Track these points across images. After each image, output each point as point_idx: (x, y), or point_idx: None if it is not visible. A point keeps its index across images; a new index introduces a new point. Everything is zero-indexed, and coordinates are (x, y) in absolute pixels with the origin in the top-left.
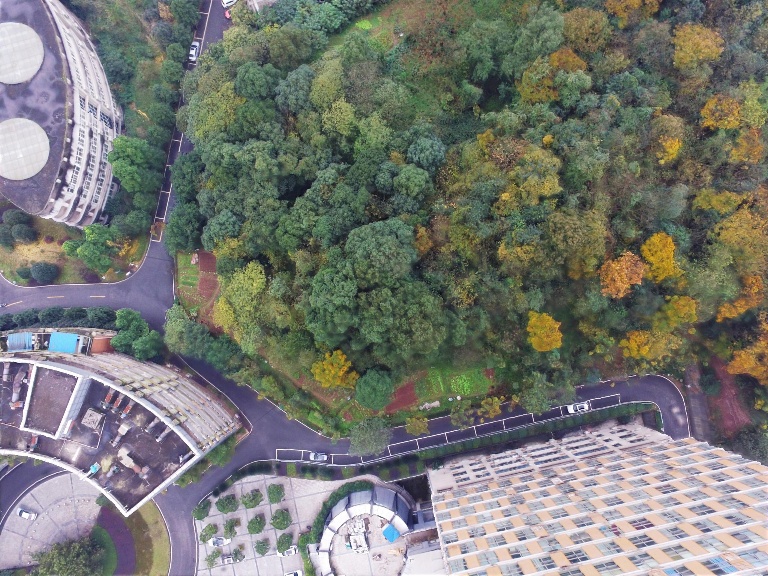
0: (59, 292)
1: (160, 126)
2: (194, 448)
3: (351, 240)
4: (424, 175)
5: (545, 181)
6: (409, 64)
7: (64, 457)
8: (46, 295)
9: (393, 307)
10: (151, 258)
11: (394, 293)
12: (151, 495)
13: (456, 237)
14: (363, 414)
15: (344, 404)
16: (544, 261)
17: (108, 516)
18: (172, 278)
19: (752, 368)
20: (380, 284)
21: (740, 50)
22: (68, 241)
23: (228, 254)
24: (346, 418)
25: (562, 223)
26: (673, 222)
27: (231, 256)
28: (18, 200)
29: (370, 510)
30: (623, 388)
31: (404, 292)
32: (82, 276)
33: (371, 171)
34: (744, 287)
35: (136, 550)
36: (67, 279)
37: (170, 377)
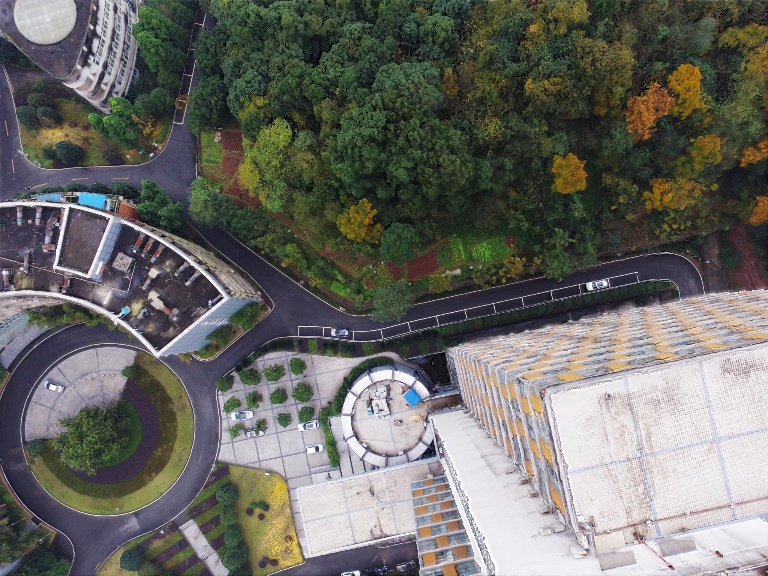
0: (83, 174)
1: (183, 5)
2: (223, 291)
3: (379, 77)
4: (450, 22)
5: (574, 6)
6: None
7: (95, 300)
8: (71, 177)
9: (421, 139)
10: (174, 140)
11: (422, 127)
12: (181, 336)
13: (482, 82)
14: (385, 281)
15: (366, 272)
16: (571, 92)
17: (133, 390)
18: (195, 160)
19: None
20: (408, 116)
21: None
22: (94, 113)
23: (254, 112)
24: (368, 286)
25: (590, 47)
26: None
27: (257, 115)
28: (46, 64)
29: (392, 375)
30: (642, 266)
31: (431, 127)
32: (106, 158)
33: (397, 21)
34: None
35: (161, 423)
36: (91, 162)
37: (195, 246)
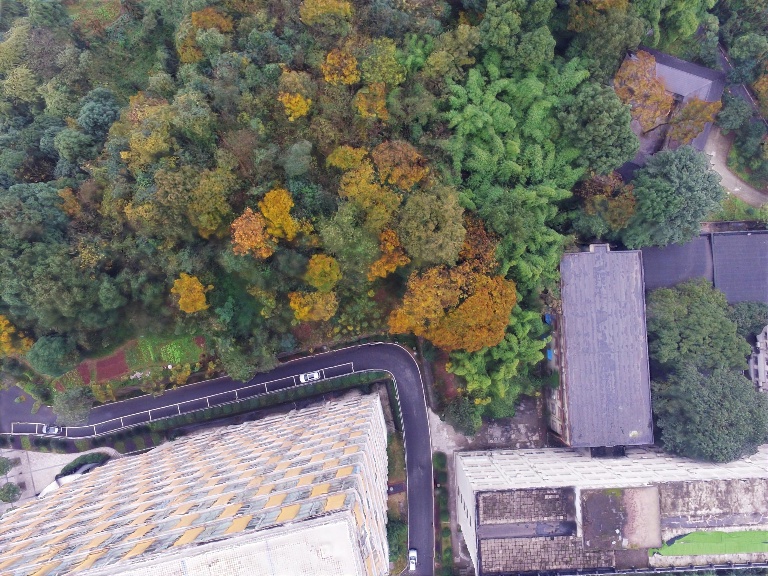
0: None
1: None
2: None
3: None
4: (78, 138)
5: (149, 137)
6: (131, 33)
7: None
8: None
9: (16, 268)
10: None
11: (20, 254)
12: None
13: (106, 199)
14: (73, 384)
15: None
16: (163, 219)
17: None
18: None
19: (413, 328)
20: None
21: (383, 7)
22: None
23: None
24: (57, 388)
25: (162, 179)
26: (308, 180)
27: None
28: None
29: None
30: (356, 357)
31: (32, 253)
32: None
33: (32, 135)
34: (380, 244)
35: None
36: None
37: None
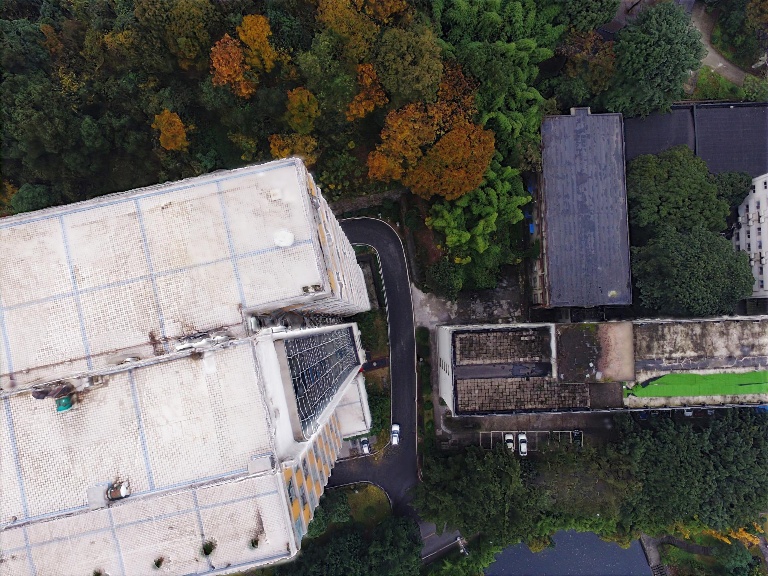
0: None
1: None
2: None
3: None
4: None
5: None
6: None
7: None
8: None
9: None
10: None
11: (2, 82)
12: None
13: None
14: None
15: None
16: (142, 44)
17: None
18: None
19: (391, 171)
20: None
21: None
22: None
23: None
24: None
25: None
26: (286, 12)
27: None
28: None
29: None
30: None
31: (15, 82)
32: None
33: None
34: None
35: None
36: None
37: None
